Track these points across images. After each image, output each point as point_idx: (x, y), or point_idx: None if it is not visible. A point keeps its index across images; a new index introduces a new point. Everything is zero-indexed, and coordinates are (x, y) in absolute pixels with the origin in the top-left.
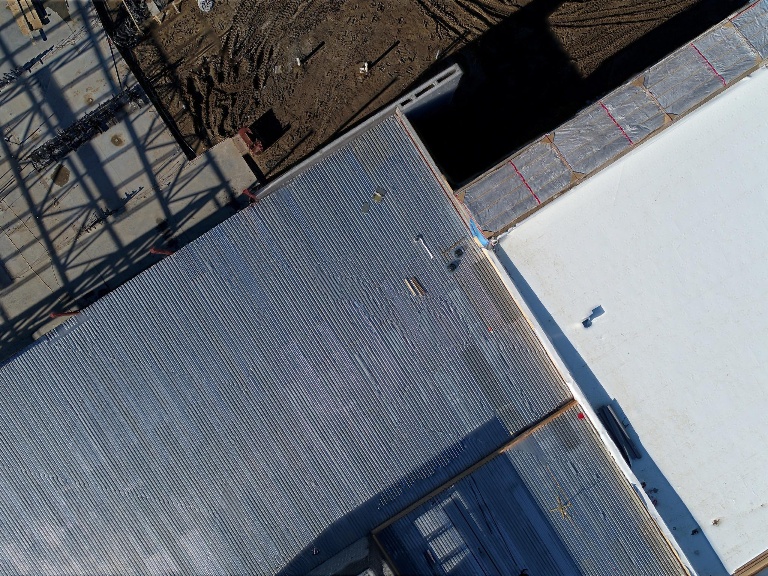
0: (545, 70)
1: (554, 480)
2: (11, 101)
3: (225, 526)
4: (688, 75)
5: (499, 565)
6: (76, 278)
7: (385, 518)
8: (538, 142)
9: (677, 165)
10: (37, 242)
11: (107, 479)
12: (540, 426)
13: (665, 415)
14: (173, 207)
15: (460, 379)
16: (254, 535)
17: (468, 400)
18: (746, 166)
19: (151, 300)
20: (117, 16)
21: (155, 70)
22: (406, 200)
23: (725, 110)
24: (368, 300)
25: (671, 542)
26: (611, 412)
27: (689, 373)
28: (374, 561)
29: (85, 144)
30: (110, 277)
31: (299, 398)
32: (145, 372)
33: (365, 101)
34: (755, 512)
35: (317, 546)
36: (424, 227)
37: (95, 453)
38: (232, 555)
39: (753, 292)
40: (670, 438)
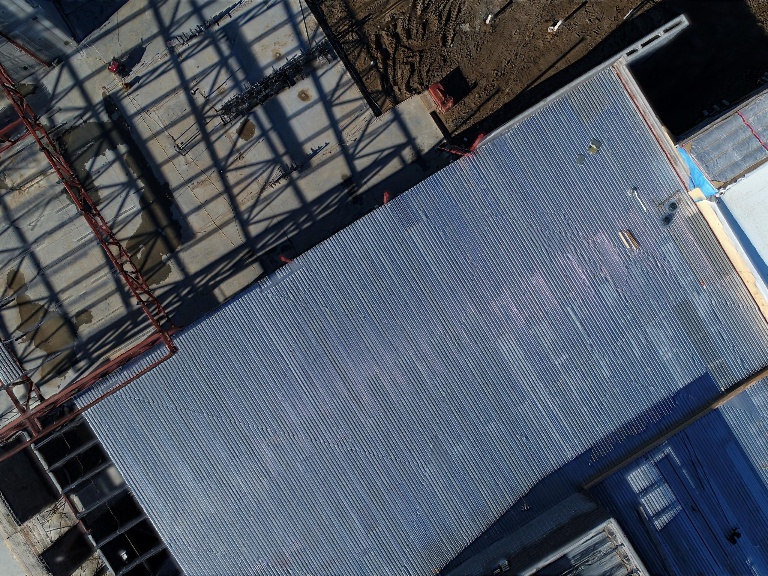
0: (731, 33)
1: (767, 437)
2: (198, 54)
3: (435, 480)
4: None
5: (711, 523)
6: (259, 234)
7: (596, 474)
8: (765, 94)
9: None
10: (221, 197)
11: (317, 431)
12: (755, 382)
13: None
14: (359, 163)
15: (672, 334)
16: (464, 490)
17: (680, 355)
18: None
19: (365, 249)
20: None
21: (342, 26)
22: (621, 153)
23: None
24: (576, 254)
25: None
26: None
27: None
28: None
29: (272, 98)
30: (294, 233)
31: (511, 351)
32: (357, 322)
33: (552, 60)
34: None
35: (528, 502)
36: (638, 180)
37: (305, 404)
38: (442, 510)
39: None
40: None
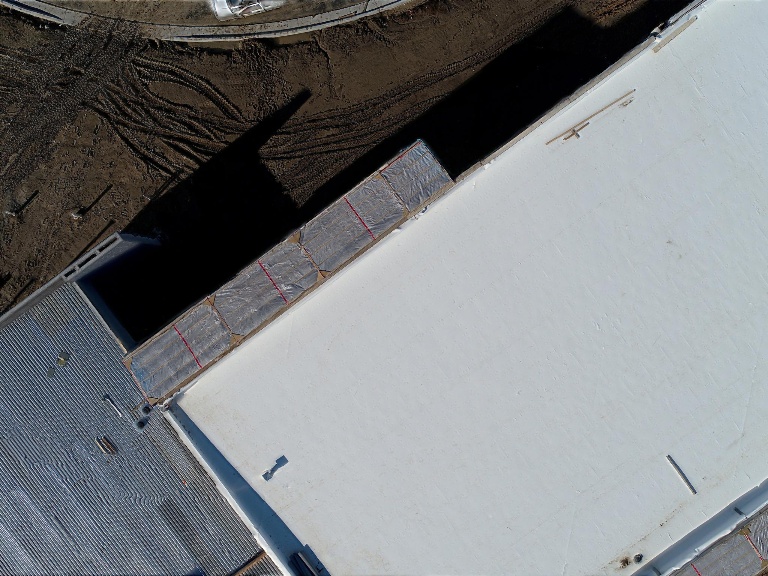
0: (259, 203)
1: None
2: None
3: None
4: (340, 230)
5: None
6: None
7: None
8: (200, 305)
9: (346, 314)
10: None
11: None
12: (237, 575)
13: (359, 557)
14: None
15: (158, 533)
16: None
17: (167, 553)
18: (415, 310)
19: None
20: None
21: None
22: (90, 362)
23: (389, 257)
24: (68, 458)
25: None
26: (302, 559)
27: (378, 514)
28: None
29: None
30: None
31: None
32: None
33: (83, 246)
34: None
35: None
36: (110, 387)
37: None
38: None
39: (435, 431)
40: None
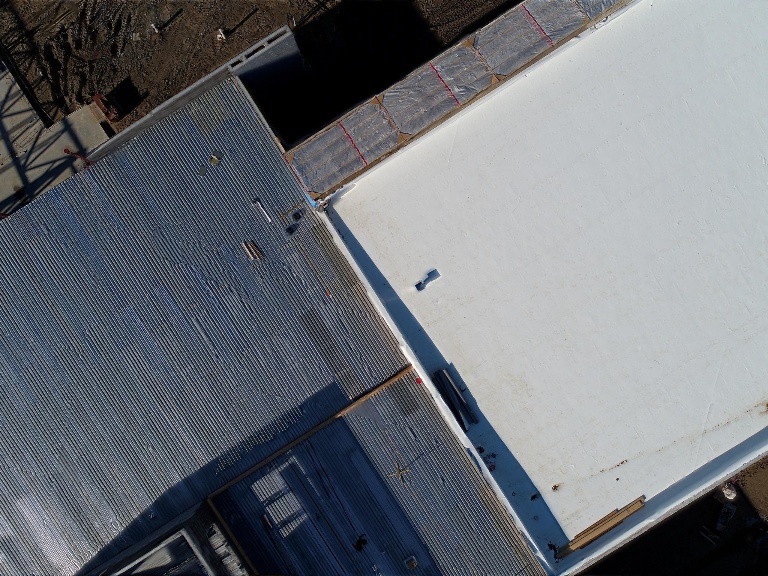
0: (405, 38)
1: (392, 445)
2: None
3: (61, 490)
4: (517, 36)
5: (337, 530)
6: None
7: (223, 483)
8: (367, 103)
9: (512, 128)
10: None
11: None
12: (377, 391)
13: (503, 380)
14: (30, 175)
15: (299, 344)
16: (91, 500)
17: (307, 365)
18: (581, 129)
19: None
20: None
21: (12, 37)
22: (243, 163)
23: (559, 72)
24: (210, 265)
25: (506, 507)
26: (447, 376)
27: (526, 337)
28: (195, 523)
29: None
30: None
31: (136, 362)
32: None
33: None
34: (595, 478)
35: (154, 511)
36: (262, 191)
37: None
38: (68, 519)
39: (590, 256)
40: (508, 403)
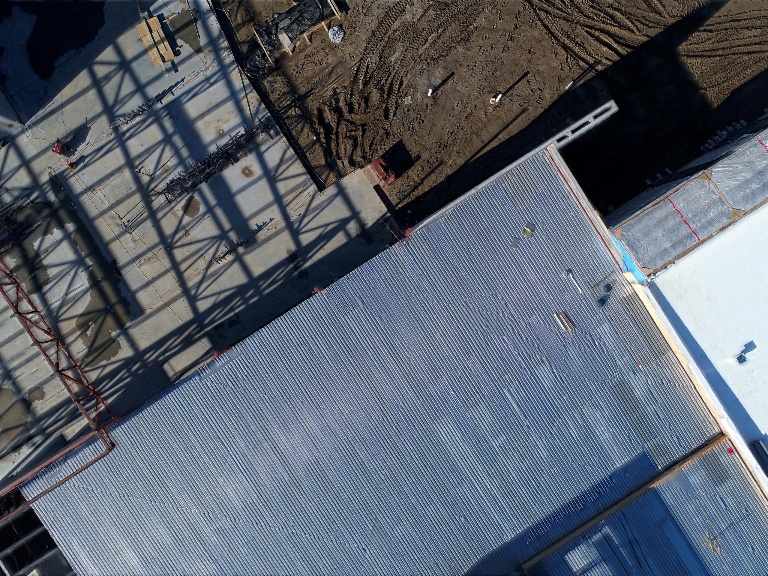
0: (674, 100)
1: (703, 514)
2: (142, 133)
3: (375, 561)
4: None
5: None
6: (206, 309)
7: (534, 553)
8: (695, 178)
9: None
10: (168, 273)
11: (258, 515)
12: (690, 461)
13: None
14: (303, 238)
15: (609, 414)
16: (404, 570)
17: (616, 434)
18: None
19: (302, 336)
20: (248, 47)
21: (285, 101)
22: (555, 235)
23: None
24: (513, 334)
25: None
26: (763, 447)
27: None
28: None
29: (216, 175)
30: (240, 308)
31: (449, 433)
32: (296, 408)
33: (495, 131)
34: None
35: None
36: (573, 262)
37: (246, 489)
38: None
39: None
40: None
